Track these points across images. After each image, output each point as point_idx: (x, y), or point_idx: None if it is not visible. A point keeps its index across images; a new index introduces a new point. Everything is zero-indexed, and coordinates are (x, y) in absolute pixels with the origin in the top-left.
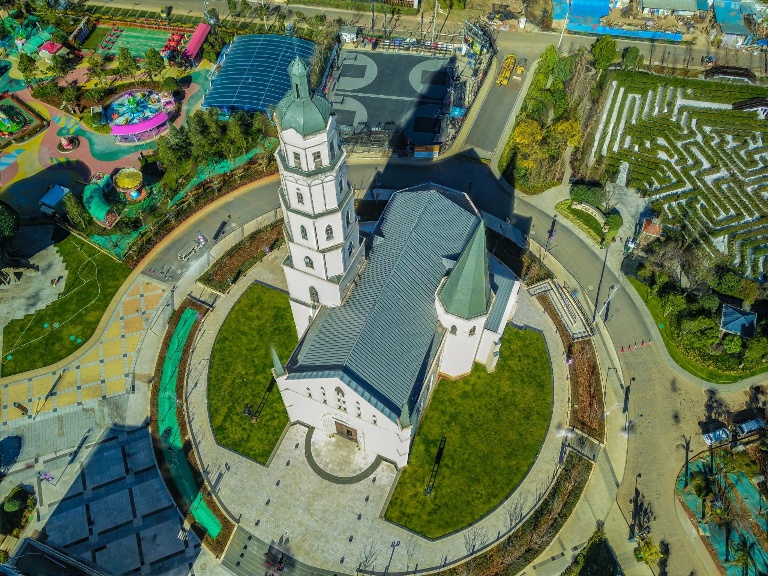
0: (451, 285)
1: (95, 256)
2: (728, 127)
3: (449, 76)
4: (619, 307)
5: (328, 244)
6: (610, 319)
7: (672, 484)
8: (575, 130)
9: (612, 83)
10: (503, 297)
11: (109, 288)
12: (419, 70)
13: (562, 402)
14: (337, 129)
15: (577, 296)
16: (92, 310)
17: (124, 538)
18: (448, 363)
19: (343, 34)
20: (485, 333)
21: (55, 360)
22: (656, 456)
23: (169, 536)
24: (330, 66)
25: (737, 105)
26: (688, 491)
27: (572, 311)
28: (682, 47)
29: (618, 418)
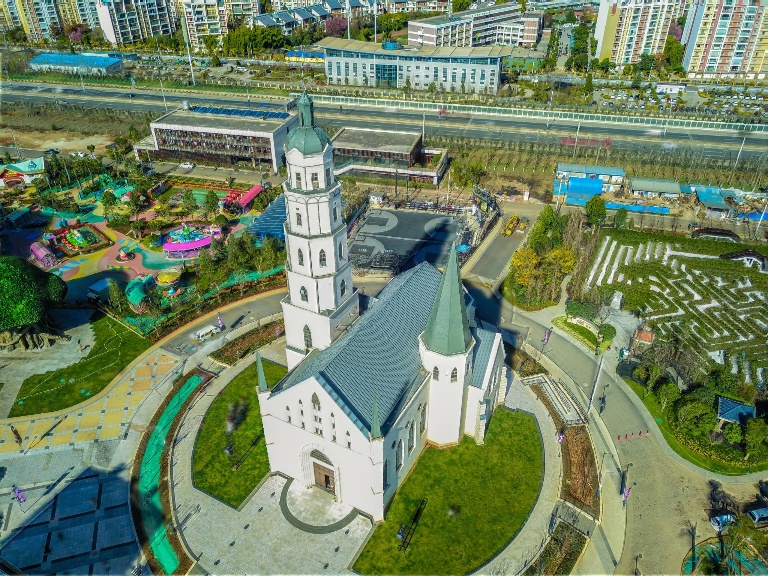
0: (431, 320)
1: (123, 333)
2: (717, 271)
3: (460, 228)
4: (615, 402)
5: (321, 272)
6: (604, 408)
7: (678, 567)
8: (567, 256)
9: (606, 237)
10: (486, 351)
11: (128, 356)
12: (434, 223)
13: (553, 477)
14: (356, 257)
15: (572, 390)
16: (107, 371)
17: (76, 568)
18: (435, 427)
19: (371, 197)
20: (470, 391)
21: (61, 407)
22: (658, 538)
23: (123, 570)
24: (357, 216)
25: (724, 256)
26: (696, 575)
27: (566, 402)
28: (670, 217)
29: (615, 498)
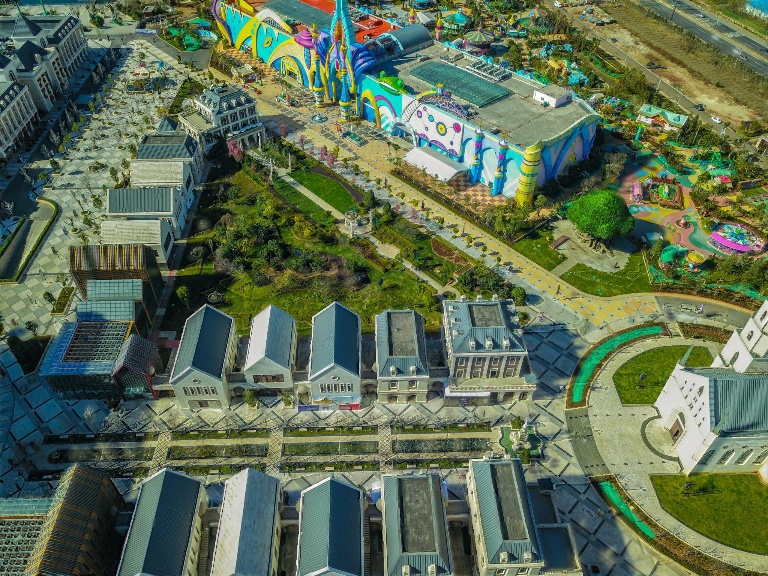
0: None
1: (643, 273)
2: None
3: None
4: None
5: None
6: None
7: None
8: None
9: None
10: None
11: (634, 288)
12: None
13: None
14: None
15: None
16: (618, 289)
17: (542, 365)
18: None
19: None
20: None
21: (584, 291)
22: None
23: (557, 382)
24: None
25: None
26: None
27: None
28: None
29: None
